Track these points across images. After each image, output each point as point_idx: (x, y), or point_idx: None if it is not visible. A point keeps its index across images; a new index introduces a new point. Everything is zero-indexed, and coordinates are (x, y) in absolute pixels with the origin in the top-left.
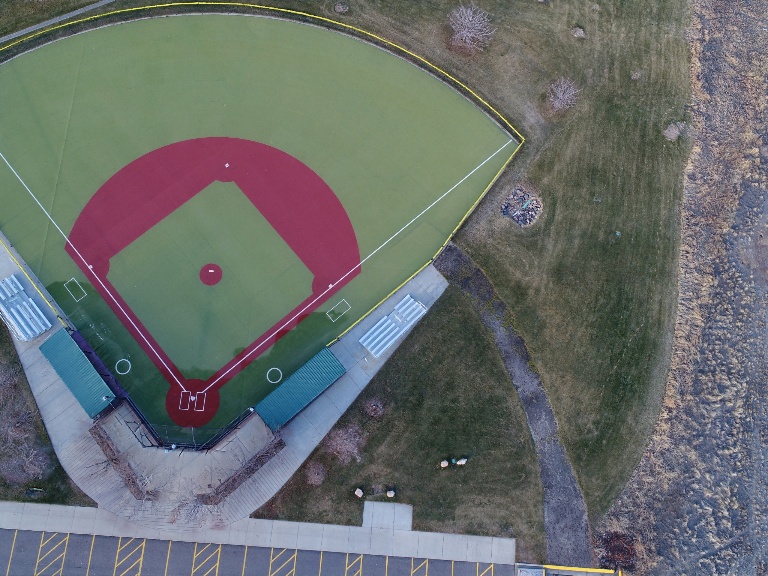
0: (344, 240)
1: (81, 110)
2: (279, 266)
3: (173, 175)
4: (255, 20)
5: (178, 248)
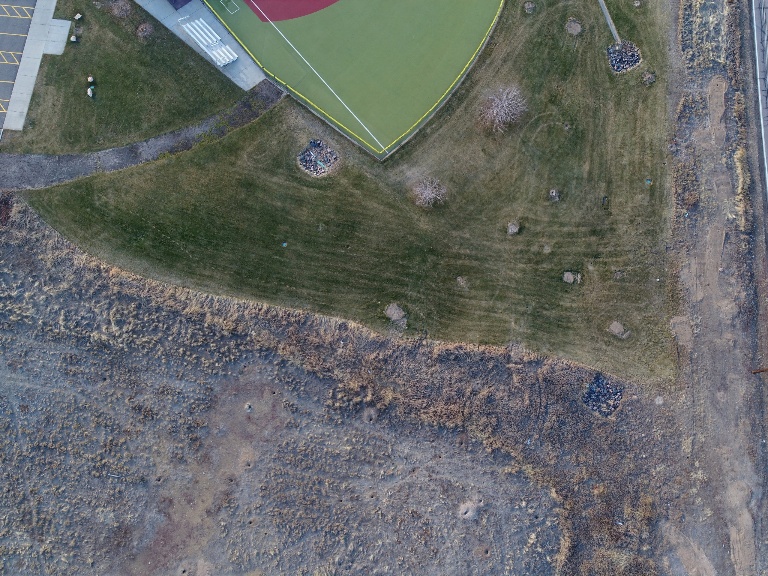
0: (293, 9)
1: None
2: None
3: None
4: None
5: None
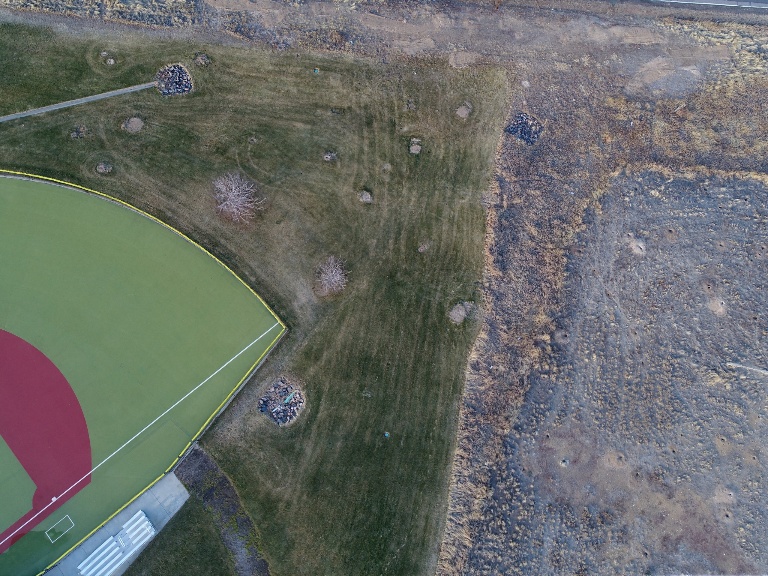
0: (76, 443)
1: None
2: None
3: None
4: (6, 182)
5: None
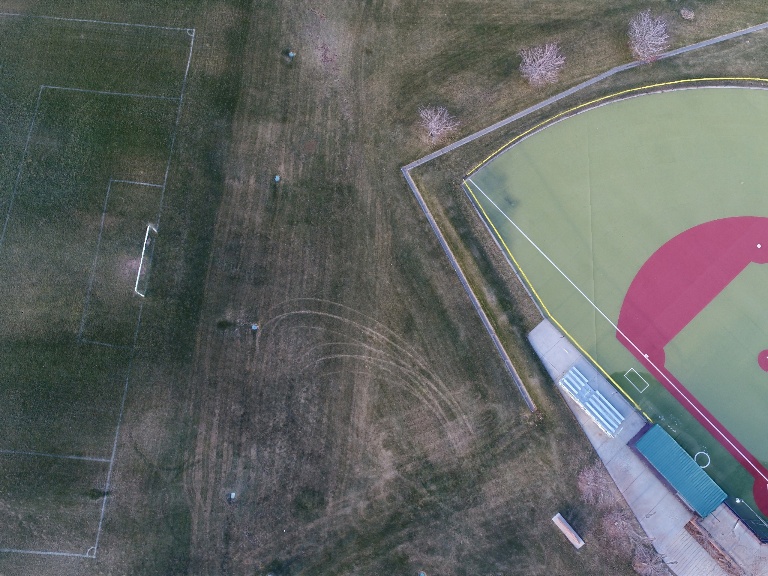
0: None
1: (600, 193)
2: None
3: (707, 258)
4: (752, 92)
5: (730, 334)
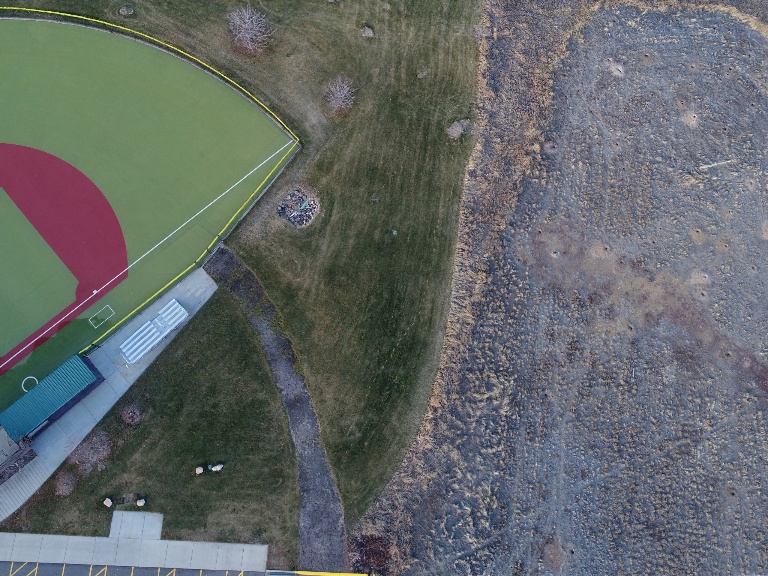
0: (112, 245)
1: None
2: (43, 273)
3: None
4: (36, 24)
5: None
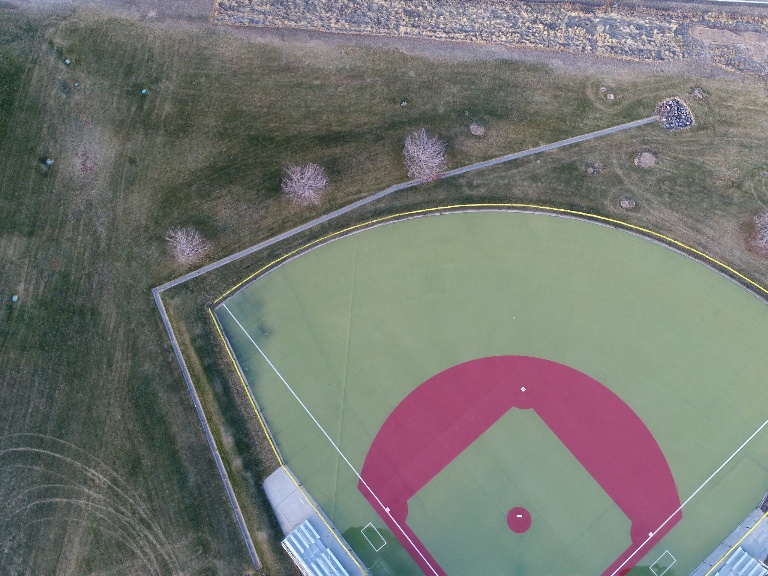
0: (660, 479)
1: (360, 324)
2: (592, 510)
3: (466, 401)
4: (536, 218)
5: (480, 488)
